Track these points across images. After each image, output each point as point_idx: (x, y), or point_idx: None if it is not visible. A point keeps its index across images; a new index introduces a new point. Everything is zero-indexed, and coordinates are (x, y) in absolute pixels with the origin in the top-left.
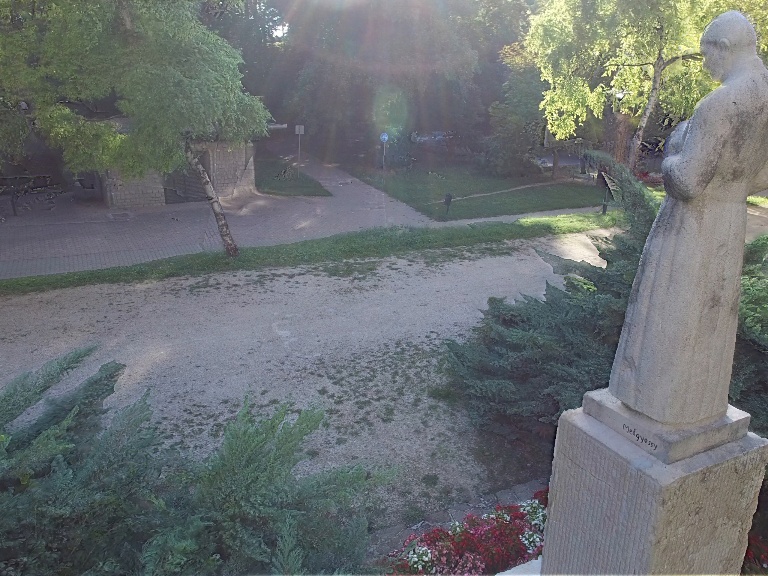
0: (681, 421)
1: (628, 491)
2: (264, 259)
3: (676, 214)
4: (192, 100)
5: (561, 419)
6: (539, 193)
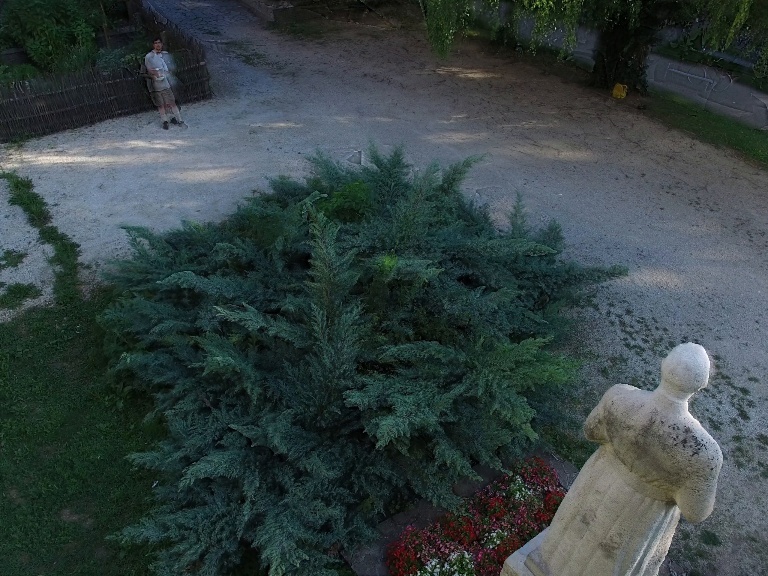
0: (549, 560)
1: None
2: None
3: None
4: None
5: None
6: None
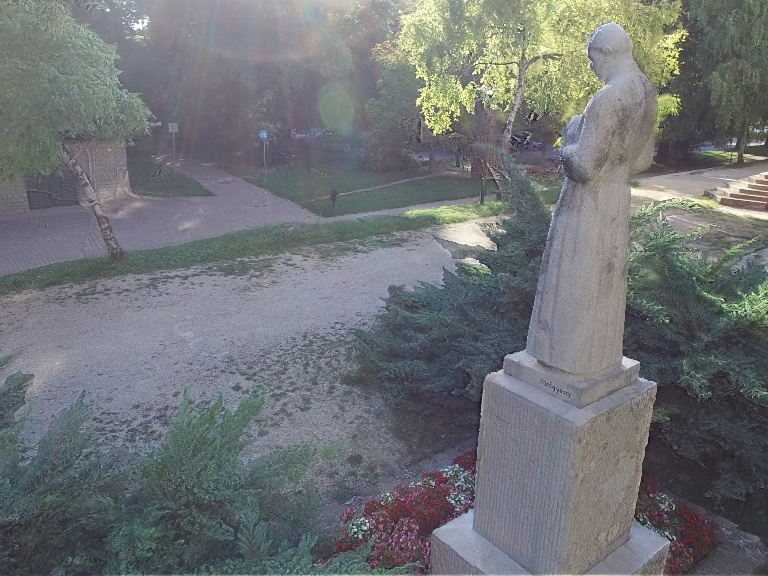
0: (588, 371)
1: (549, 436)
2: (153, 262)
3: (577, 194)
4: (71, 97)
5: (486, 381)
6: (419, 186)
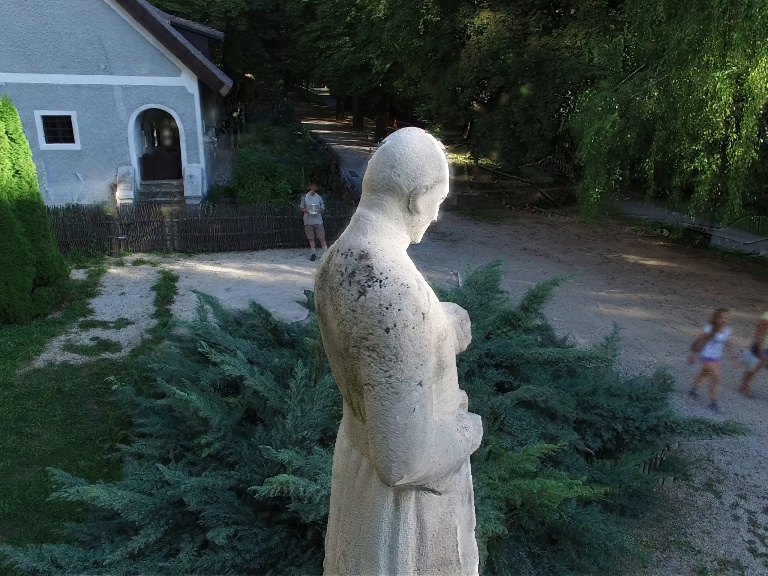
0: None
1: None
2: None
3: None
4: None
5: None
6: None
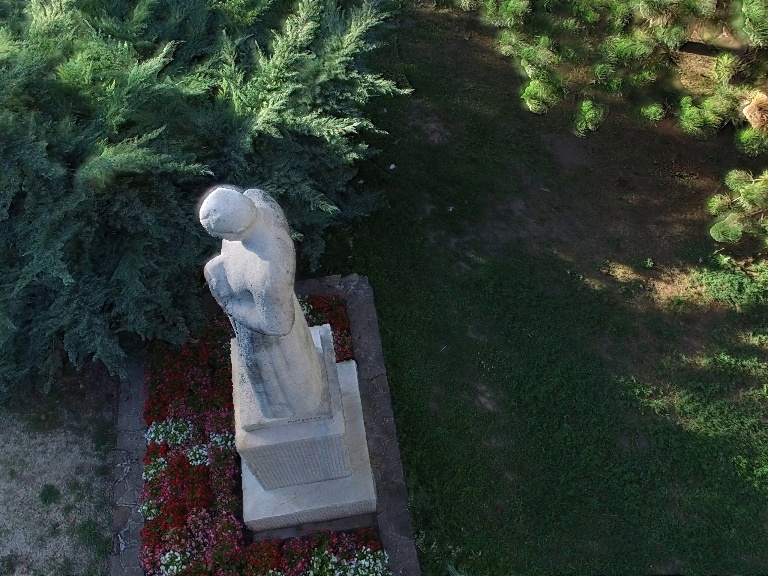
0: None
1: None
2: None
3: (269, 336)
4: None
5: None
6: None
